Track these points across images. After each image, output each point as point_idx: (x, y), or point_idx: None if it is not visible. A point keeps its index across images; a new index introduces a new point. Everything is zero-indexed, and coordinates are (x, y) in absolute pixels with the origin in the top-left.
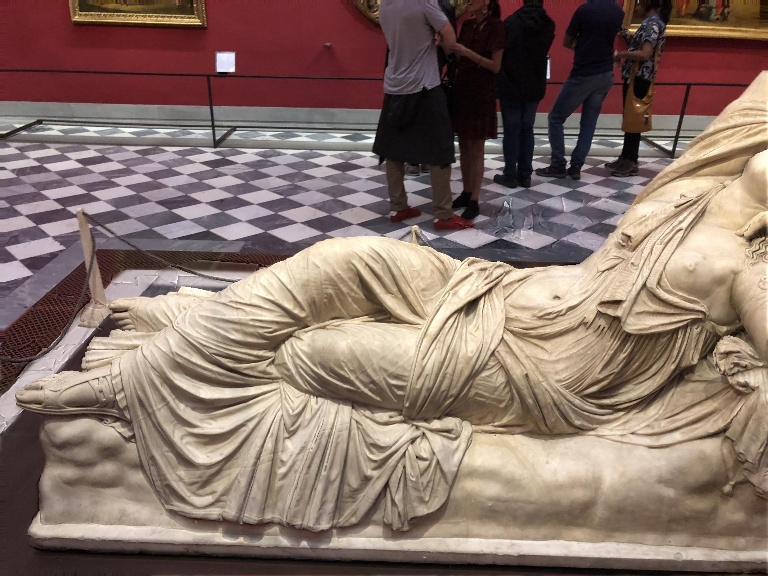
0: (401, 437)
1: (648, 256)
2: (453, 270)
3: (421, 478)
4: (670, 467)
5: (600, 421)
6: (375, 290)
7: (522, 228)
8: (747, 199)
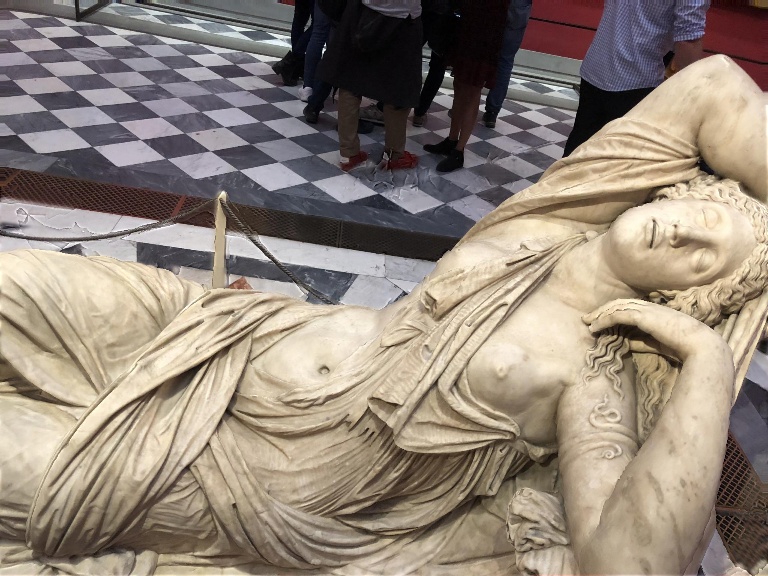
0: None
1: (450, 339)
2: (175, 312)
3: None
4: None
5: (352, 556)
6: (4, 354)
7: (402, 186)
8: (606, 271)
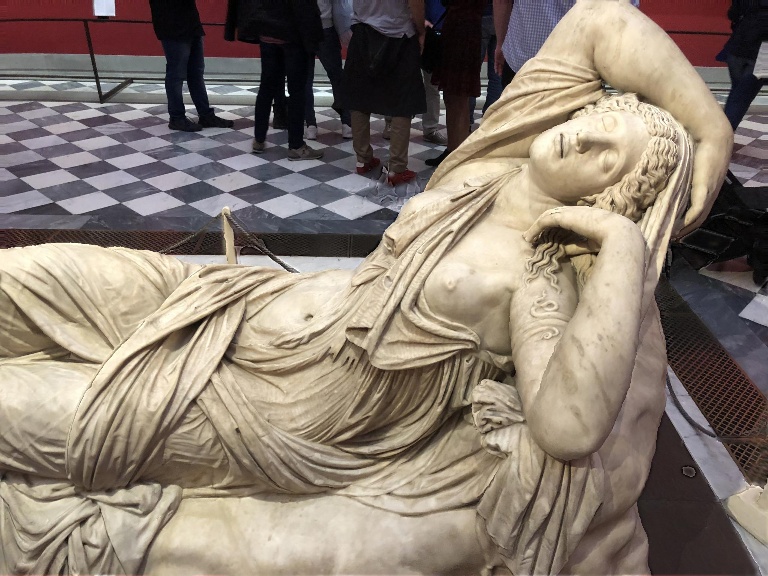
0: (61, 519)
1: (407, 268)
2: (177, 284)
3: (92, 570)
4: (417, 546)
5: (353, 477)
6: (35, 322)
7: (405, 196)
8: (536, 191)
